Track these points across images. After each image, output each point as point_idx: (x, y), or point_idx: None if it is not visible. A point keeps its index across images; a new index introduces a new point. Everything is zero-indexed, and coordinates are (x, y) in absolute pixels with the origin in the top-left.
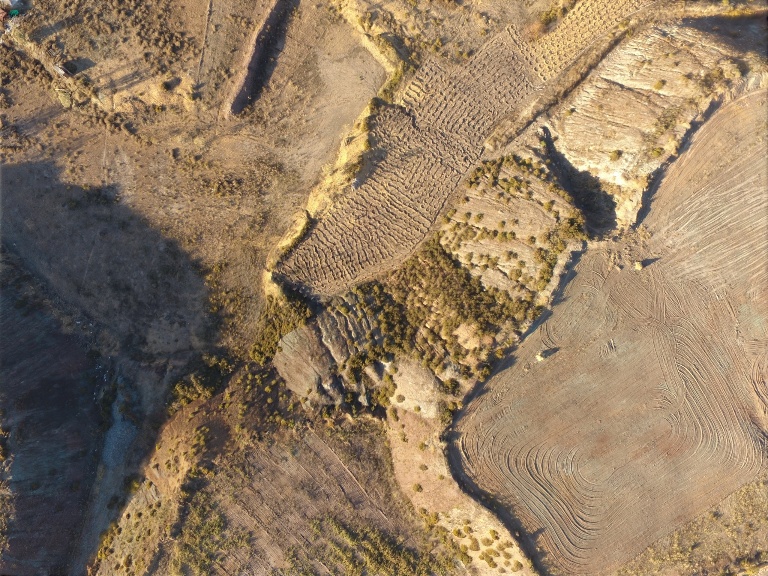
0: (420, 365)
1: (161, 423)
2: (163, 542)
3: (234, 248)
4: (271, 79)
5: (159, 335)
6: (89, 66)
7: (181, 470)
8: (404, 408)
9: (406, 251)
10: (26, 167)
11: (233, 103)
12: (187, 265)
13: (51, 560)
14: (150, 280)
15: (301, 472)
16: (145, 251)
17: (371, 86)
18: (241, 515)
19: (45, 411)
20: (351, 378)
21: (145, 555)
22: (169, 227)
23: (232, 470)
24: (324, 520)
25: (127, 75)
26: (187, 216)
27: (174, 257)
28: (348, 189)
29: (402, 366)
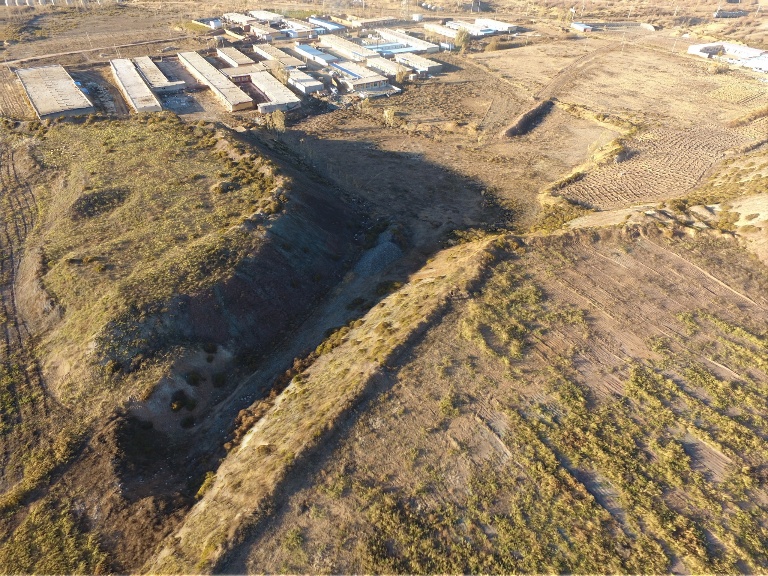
0: (763, 193)
1: (433, 251)
2: (452, 297)
3: (507, 183)
4: (533, 130)
5: (431, 214)
6: (405, 115)
7: (478, 248)
8: (763, 220)
9: (679, 192)
10: (342, 142)
11: (507, 131)
12: (463, 186)
13: (248, 339)
14: (428, 189)
15: (642, 268)
16: (426, 178)
17: (611, 136)
18: (565, 292)
19: (316, 214)
20: (677, 210)
21: (421, 310)
22: (449, 170)
23: (547, 252)
24: (697, 315)
25: (430, 119)
26: (465, 168)
27: (451, 182)
28: (610, 162)
29: (737, 202)
